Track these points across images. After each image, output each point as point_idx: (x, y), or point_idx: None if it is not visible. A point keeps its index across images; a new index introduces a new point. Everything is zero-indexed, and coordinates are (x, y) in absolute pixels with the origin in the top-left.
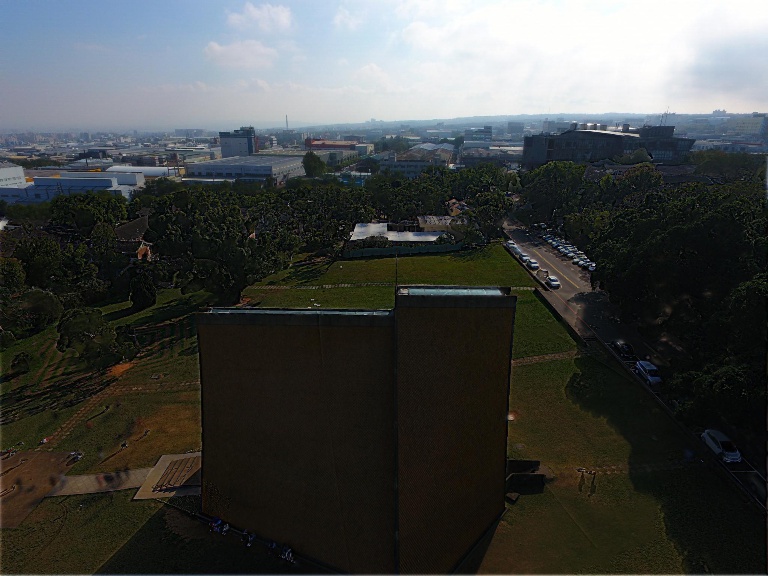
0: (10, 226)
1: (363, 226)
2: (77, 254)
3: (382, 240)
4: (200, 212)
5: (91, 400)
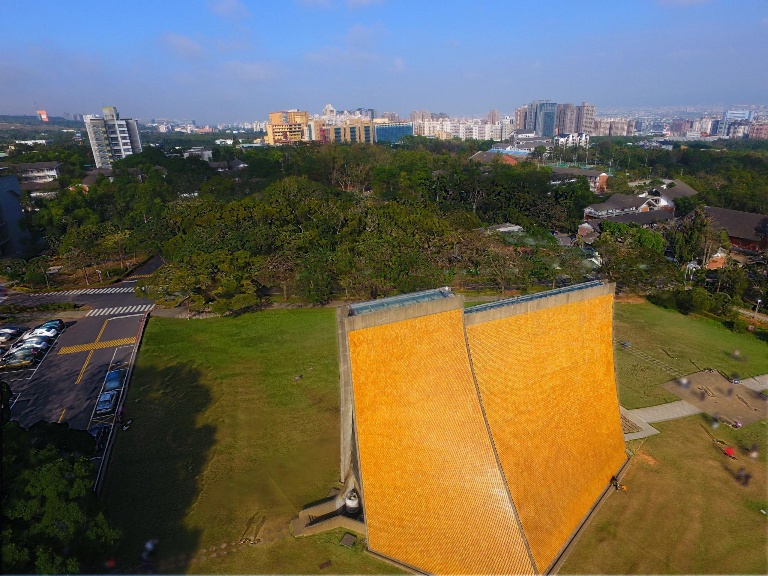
0: None
1: None
2: None
3: None
4: None
5: None
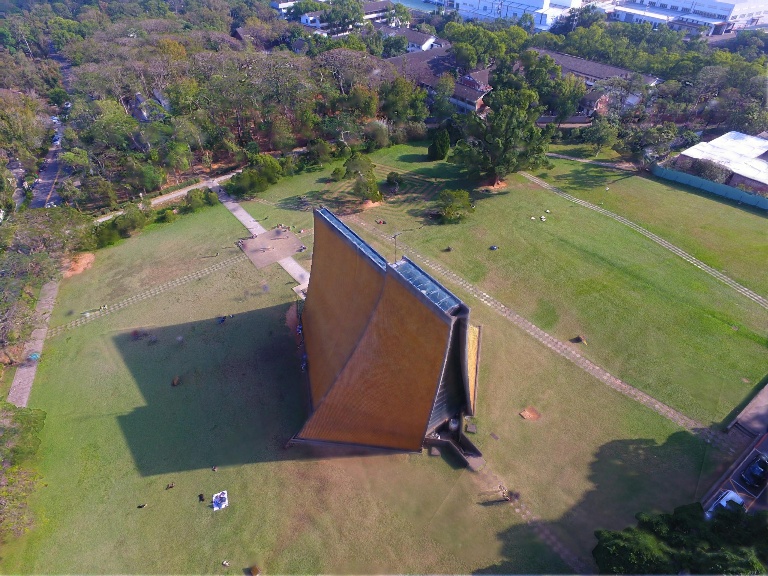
0: (435, 44)
1: (737, 137)
2: (418, 98)
3: (714, 170)
4: (535, 77)
5: None
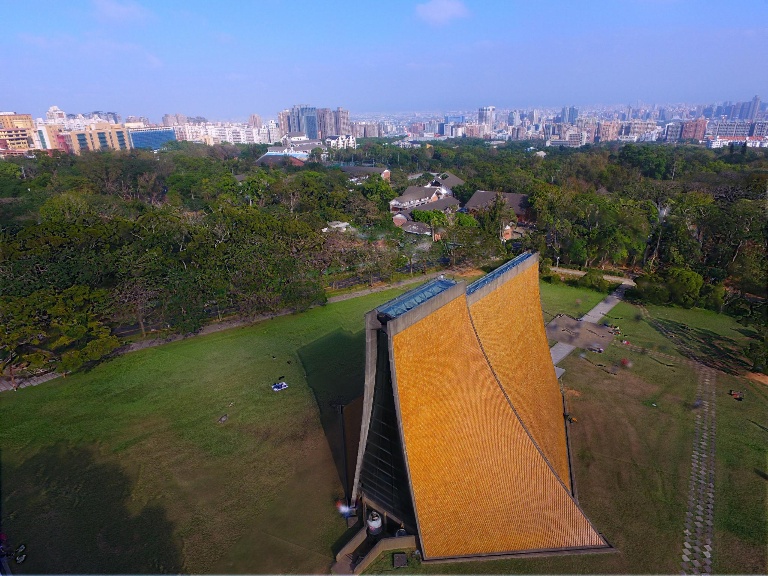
0: None
1: None
2: None
3: None
4: None
5: (689, 361)
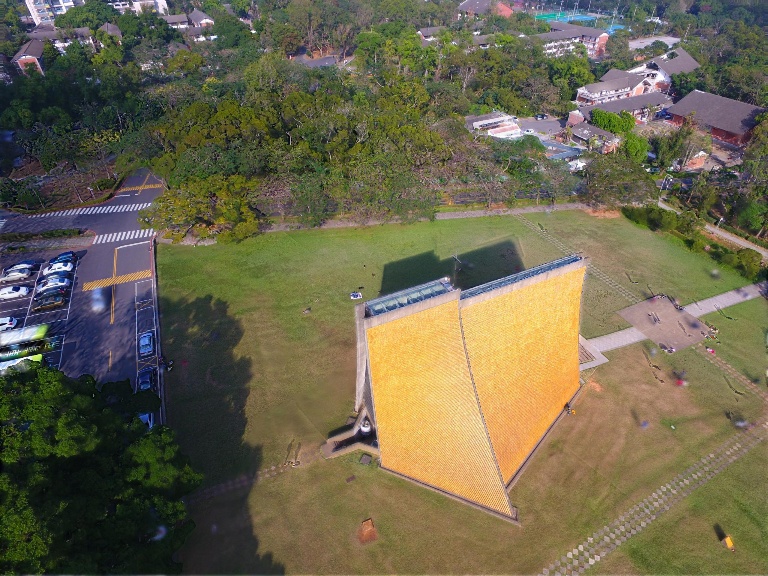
0: None
1: None
2: None
3: None
4: None
5: None
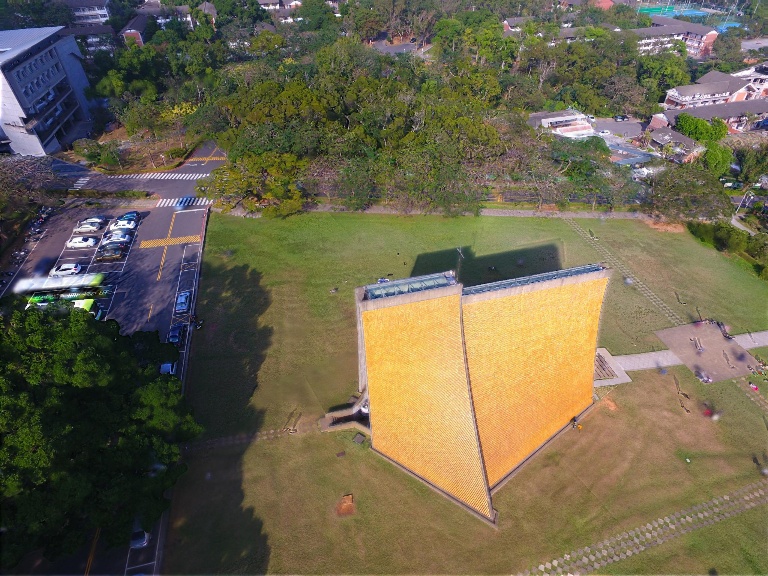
0: None
1: None
2: None
3: None
4: None
5: None
